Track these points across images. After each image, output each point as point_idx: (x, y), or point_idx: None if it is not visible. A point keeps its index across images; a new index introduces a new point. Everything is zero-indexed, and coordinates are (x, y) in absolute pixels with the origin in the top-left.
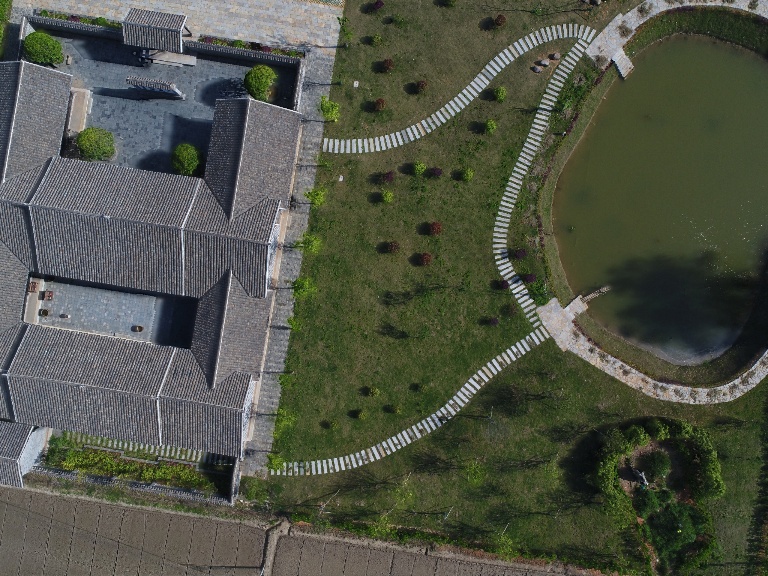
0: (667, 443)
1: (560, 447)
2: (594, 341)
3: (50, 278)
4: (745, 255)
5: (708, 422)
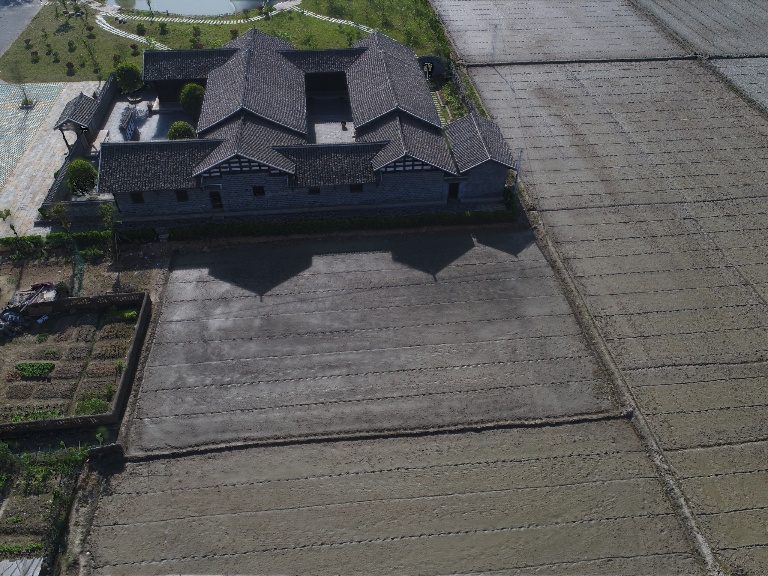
0: None
1: None
2: None
3: None
4: None
5: None
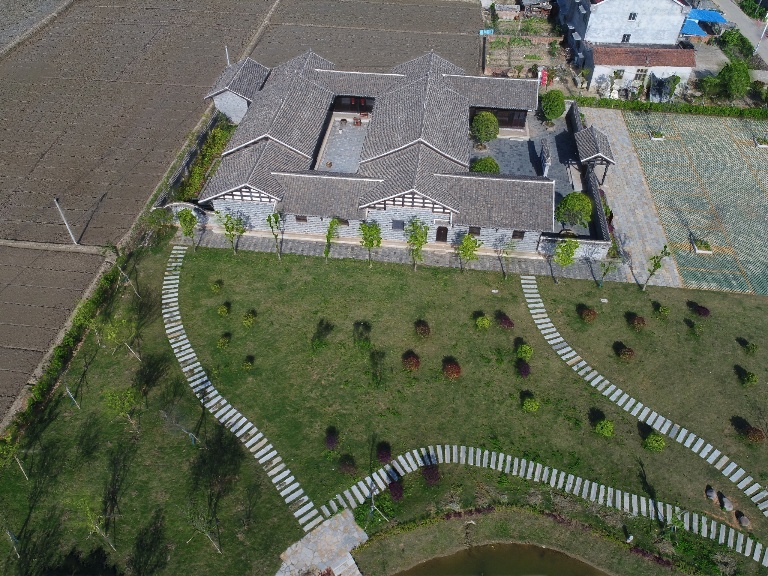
0: None
1: (124, 554)
2: None
3: None
4: None
5: None
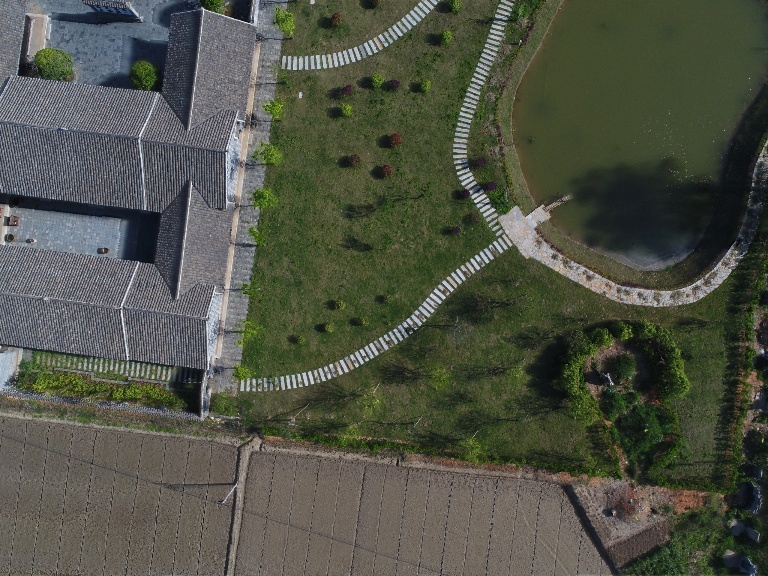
0: (632, 346)
1: (526, 353)
2: (557, 248)
3: (14, 203)
4: (705, 160)
5: (672, 323)
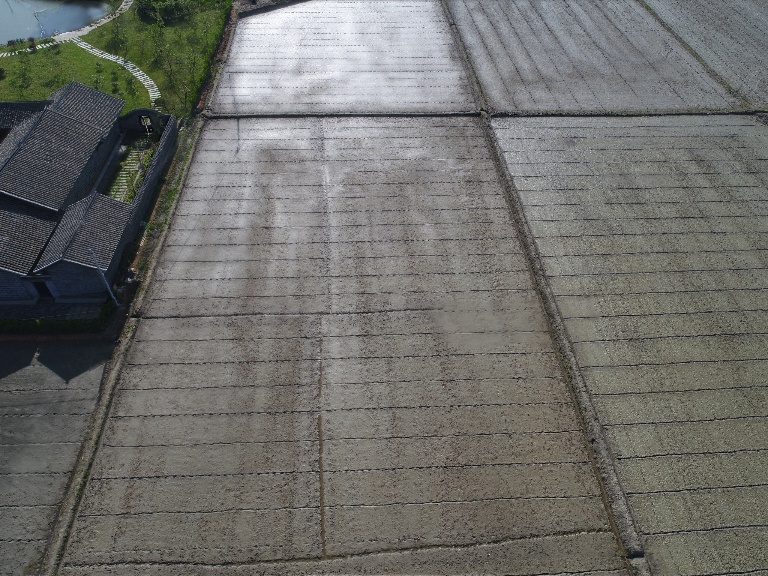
0: None
1: None
2: None
3: None
4: None
5: None
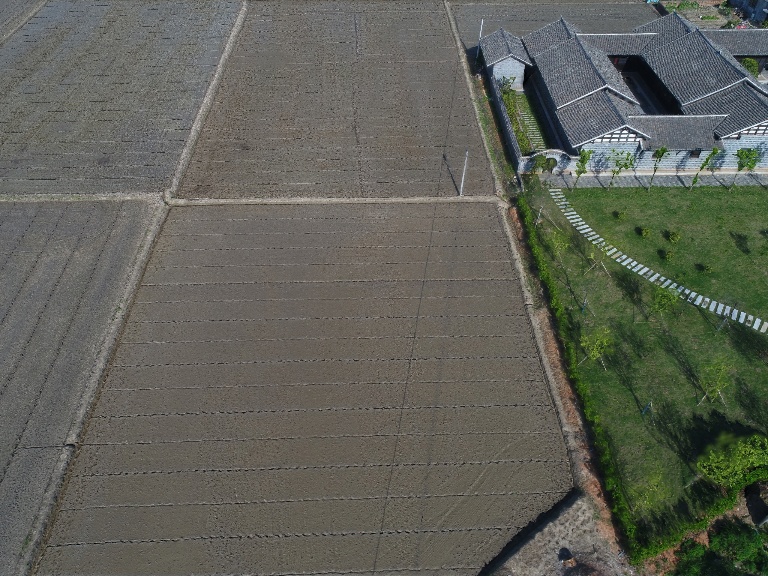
0: None
1: (735, 412)
2: None
3: (627, 78)
4: None
5: None
